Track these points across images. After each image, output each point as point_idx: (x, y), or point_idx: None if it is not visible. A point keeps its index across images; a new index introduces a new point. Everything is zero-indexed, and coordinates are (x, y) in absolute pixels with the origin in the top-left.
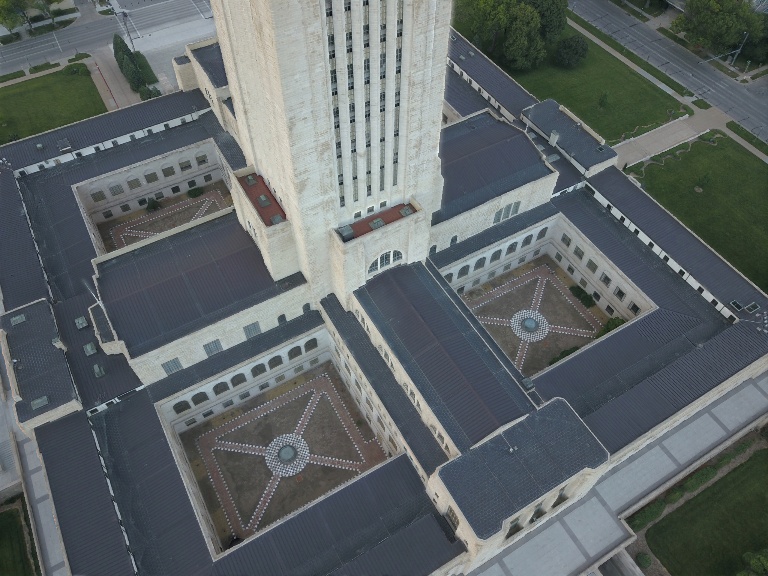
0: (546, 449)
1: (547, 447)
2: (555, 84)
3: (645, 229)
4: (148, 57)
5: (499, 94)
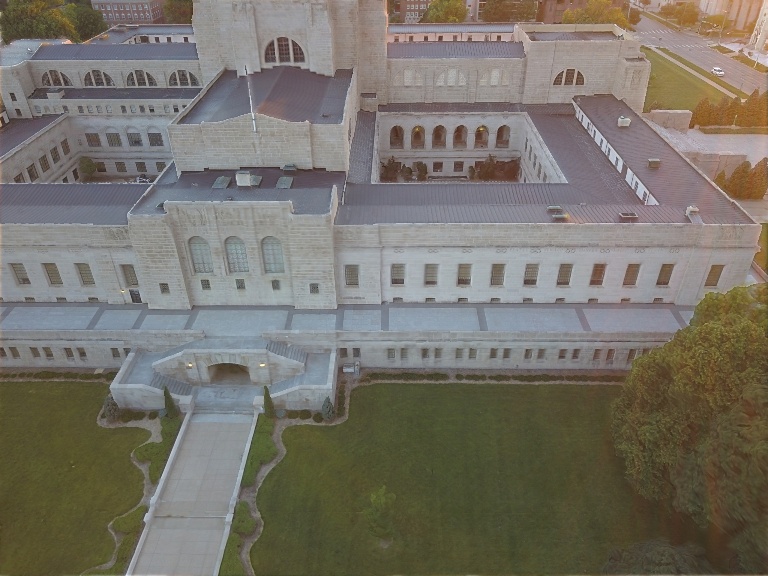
0: (6, 57)
1: (6, 58)
2: (547, 508)
3: (23, 207)
4: (767, 135)
5: (418, 209)
